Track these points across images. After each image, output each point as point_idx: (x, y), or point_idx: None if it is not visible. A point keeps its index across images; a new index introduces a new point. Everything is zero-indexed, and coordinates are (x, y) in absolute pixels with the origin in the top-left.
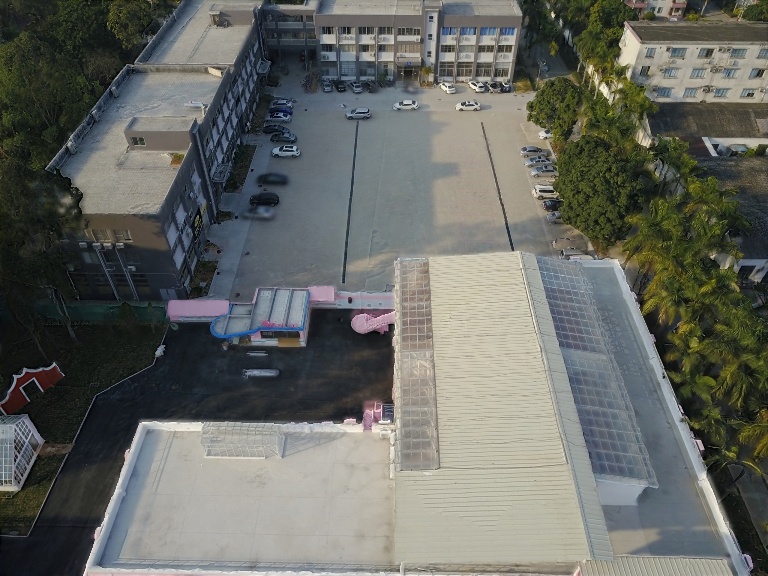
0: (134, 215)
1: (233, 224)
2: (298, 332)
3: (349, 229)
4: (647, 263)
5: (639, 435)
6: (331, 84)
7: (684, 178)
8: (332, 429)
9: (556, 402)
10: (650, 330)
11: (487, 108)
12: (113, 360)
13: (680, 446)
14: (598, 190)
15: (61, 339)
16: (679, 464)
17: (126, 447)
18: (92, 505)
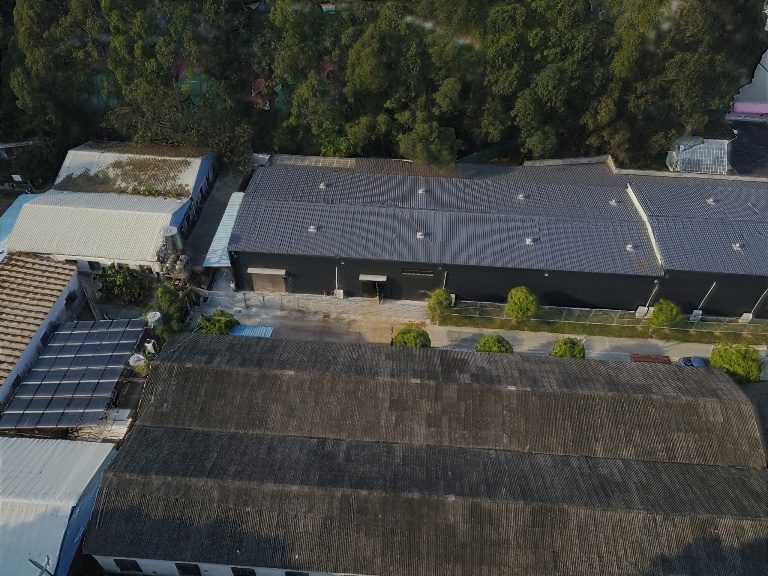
0: None
1: None
2: None
3: None
4: None
5: None
6: None
7: None
8: None
9: None
10: None
11: None
12: (708, 134)
13: None
14: None
15: None
16: None
17: (764, 168)
18: None
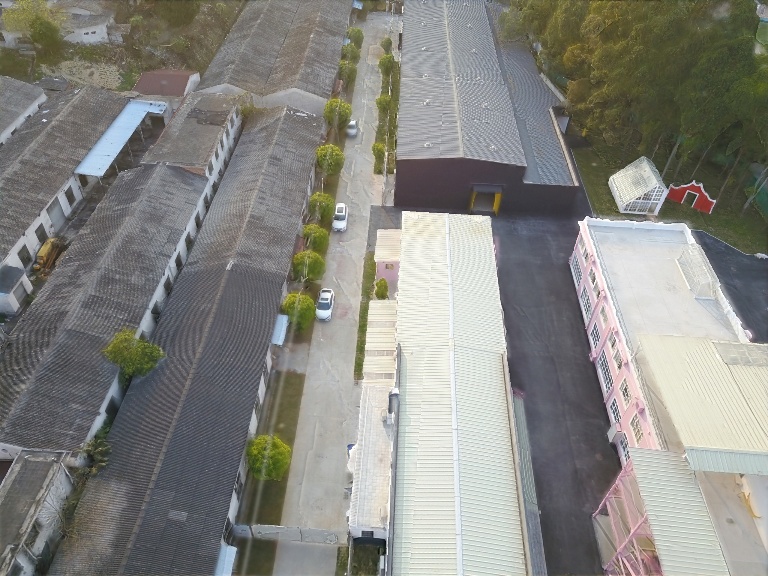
0: None
1: None
2: None
3: None
4: None
5: None
6: None
7: None
8: (735, 325)
9: None
10: None
11: None
12: (737, 234)
13: None
14: None
15: (740, 206)
16: None
17: None
18: None
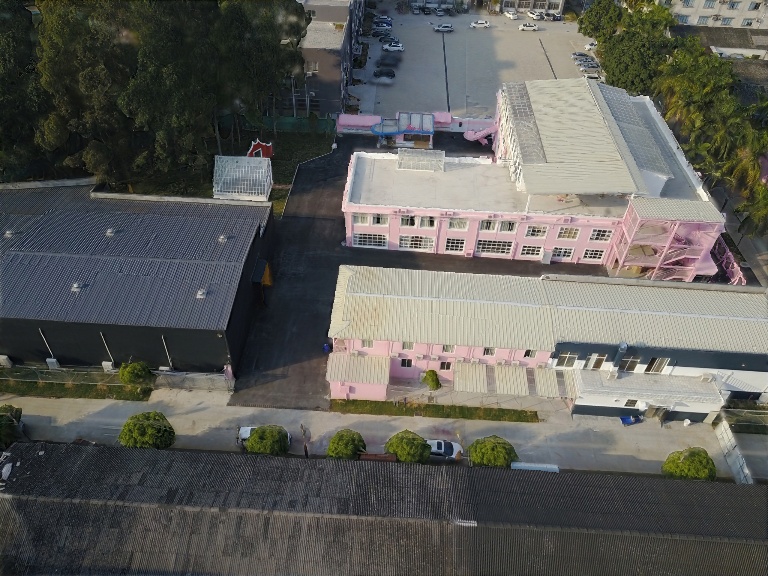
0: (325, 50)
1: (364, 87)
2: (429, 136)
3: (449, 94)
4: (669, 94)
5: (663, 159)
6: (419, 9)
7: (696, 60)
8: (472, 161)
9: (614, 138)
10: (670, 128)
11: (543, 30)
12: (303, 149)
13: (687, 178)
14: (635, 60)
15: None
16: (686, 185)
17: (327, 187)
18: (315, 209)
